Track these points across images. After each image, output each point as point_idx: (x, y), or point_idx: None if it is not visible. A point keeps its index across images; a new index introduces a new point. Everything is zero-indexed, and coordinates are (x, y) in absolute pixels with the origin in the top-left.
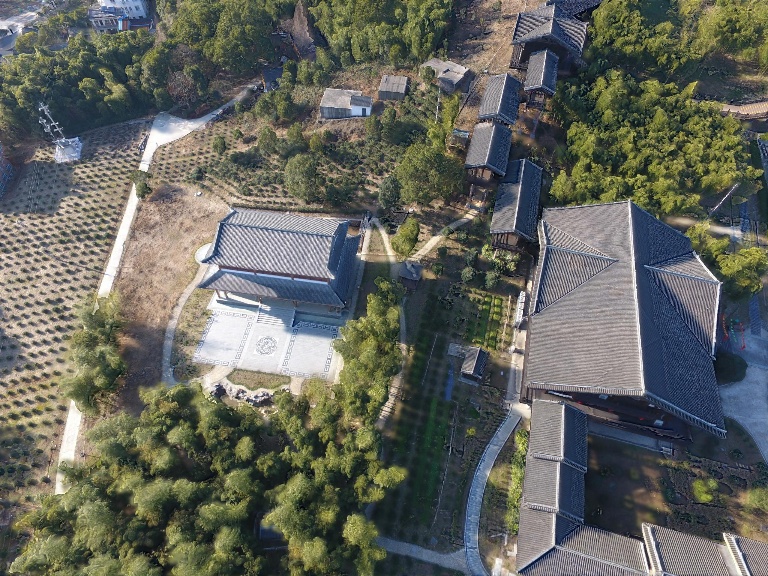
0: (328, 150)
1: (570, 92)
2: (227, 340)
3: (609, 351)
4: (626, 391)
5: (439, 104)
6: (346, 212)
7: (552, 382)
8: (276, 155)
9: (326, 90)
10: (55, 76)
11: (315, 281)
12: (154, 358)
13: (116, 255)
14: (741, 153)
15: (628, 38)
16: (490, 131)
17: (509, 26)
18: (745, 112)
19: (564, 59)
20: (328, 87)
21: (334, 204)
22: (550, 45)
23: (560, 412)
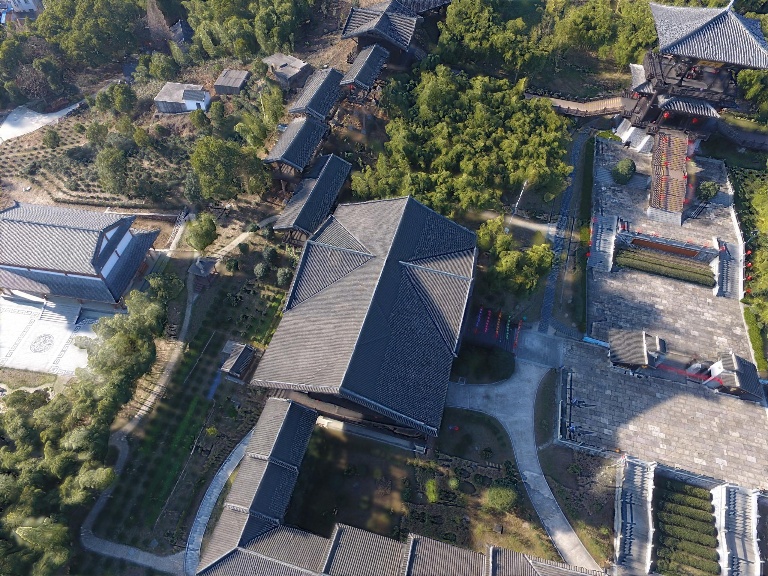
0: (159, 145)
1: (389, 87)
2: (3, 338)
3: (331, 348)
4: (327, 388)
5: None
6: (164, 208)
7: (273, 380)
8: None
9: (166, 84)
10: None
11: (88, 277)
12: None
13: None
14: (557, 150)
15: (475, 34)
16: (300, 126)
17: None
18: (587, 109)
19: (398, 54)
20: (177, 81)
21: (154, 199)
22: (381, 40)
23: (285, 410)
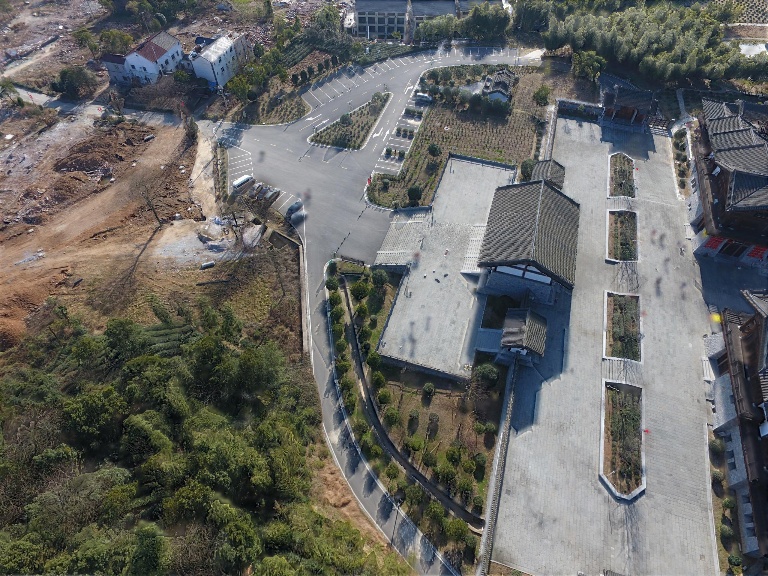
0: None
1: None
2: (745, 50)
3: None
4: None
5: None
6: None
7: None
8: None
9: None
10: None
11: None
12: None
13: (764, 25)
14: None
15: None
16: None
17: None
18: None
19: None
20: None
21: None
22: None
23: None
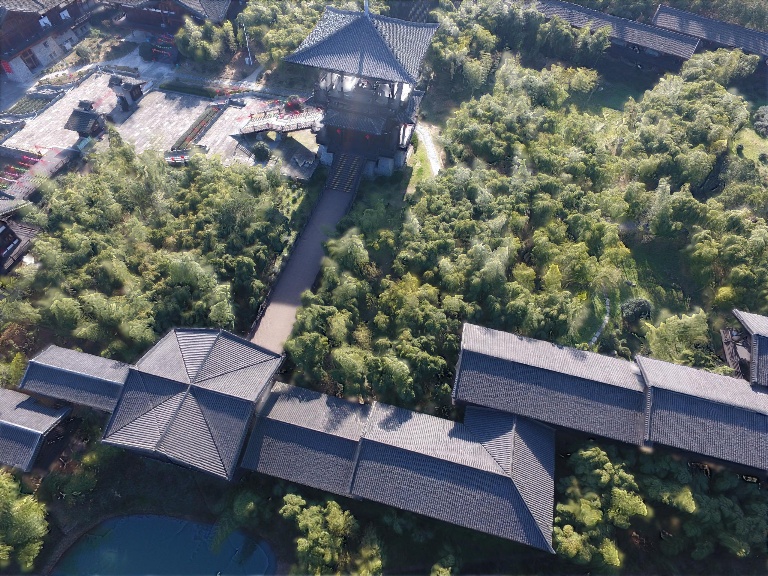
0: None
1: None
2: None
3: None
4: None
5: None
6: None
7: None
8: None
9: None
10: None
11: None
12: None
13: None
14: None
15: None
16: None
17: None
18: None
19: None
20: None
21: None
22: None
23: None
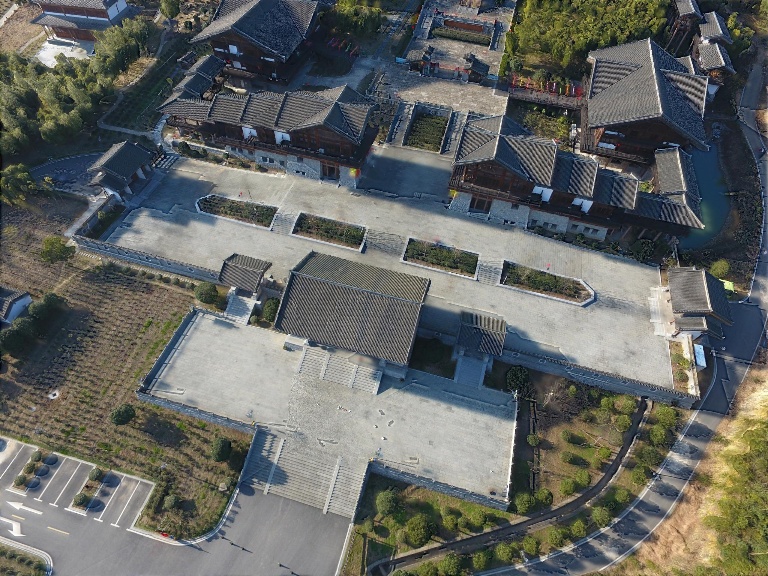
0: None
1: None
2: (49, 58)
3: None
4: (226, 29)
5: None
6: (148, 7)
7: None
8: None
9: None
10: None
11: (100, 18)
12: None
13: None
14: None
15: None
16: None
17: None
18: None
19: None
20: None
21: (142, 3)
22: None
23: None
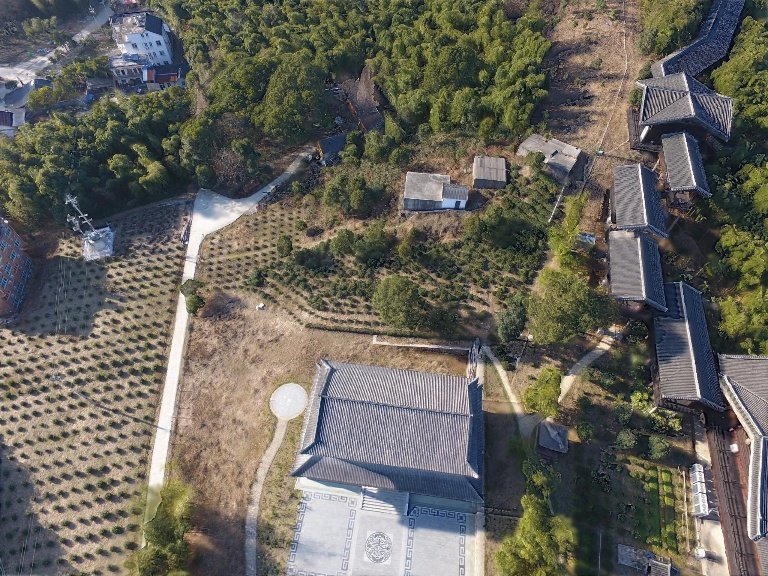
0: (417, 253)
1: (724, 190)
2: (327, 539)
3: None
4: None
5: (550, 196)
6: (449, 338)
7: None
8: (352, 256)
9: (408, 175)
10: (79, 150)
11: None
12: (235, 568)
13: (169, 397)
14: None
15: (763, 107)
16: (634, 245)
17: (613, 89)
18: None
19: (701, 140)
20: None
21: (433, 327)
22: (686, 125)
23: None
